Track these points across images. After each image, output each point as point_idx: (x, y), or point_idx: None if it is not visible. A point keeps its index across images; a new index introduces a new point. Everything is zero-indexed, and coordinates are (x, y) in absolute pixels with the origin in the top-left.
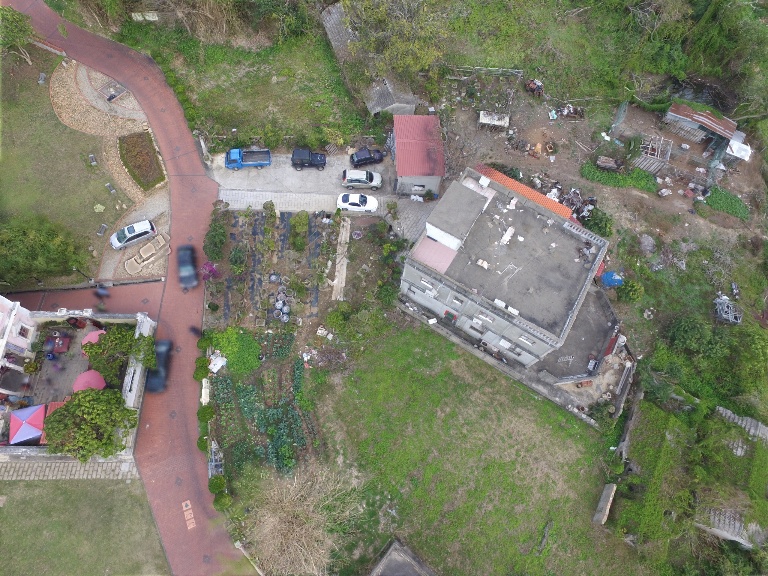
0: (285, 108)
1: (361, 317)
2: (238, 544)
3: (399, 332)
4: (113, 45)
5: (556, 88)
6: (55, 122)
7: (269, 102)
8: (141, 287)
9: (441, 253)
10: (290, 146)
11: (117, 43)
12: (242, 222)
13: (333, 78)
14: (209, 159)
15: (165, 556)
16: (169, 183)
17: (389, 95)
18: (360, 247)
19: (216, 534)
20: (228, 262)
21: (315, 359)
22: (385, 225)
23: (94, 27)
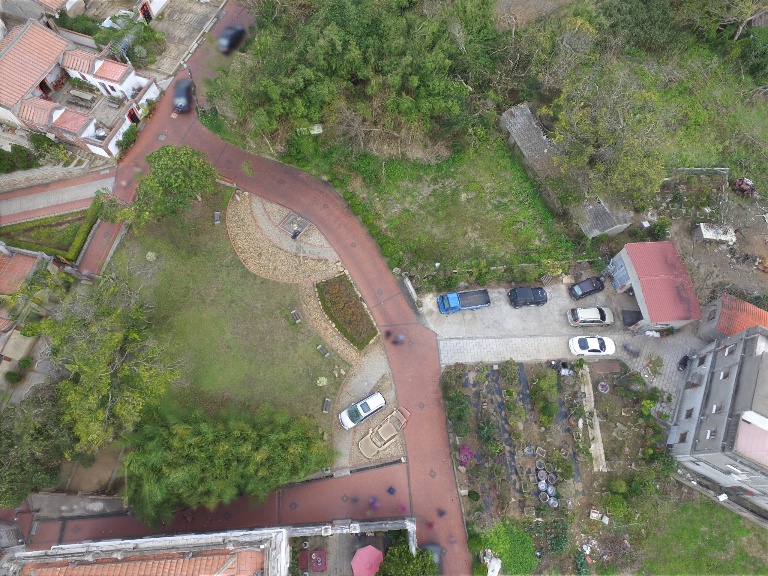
0: (485, 232)
1: (663, 511)
2: None
3: (679, 508)
4: (282, 168)
5: (763, 184)
6: (242, 271)
7: (467, 226)
8: (382, 472)
9: (760, 439)
10: (501, 279)
11: (285, 165)
12: (473, 380)
13: (529, 192)
14: (422, 305)
15: None
16: (381, 336)
17: (607, 215)
18: (607, 401)
19: None
20: (471, 433)
21: (597, 551)
22: (642, 379)
23: (258, 148)
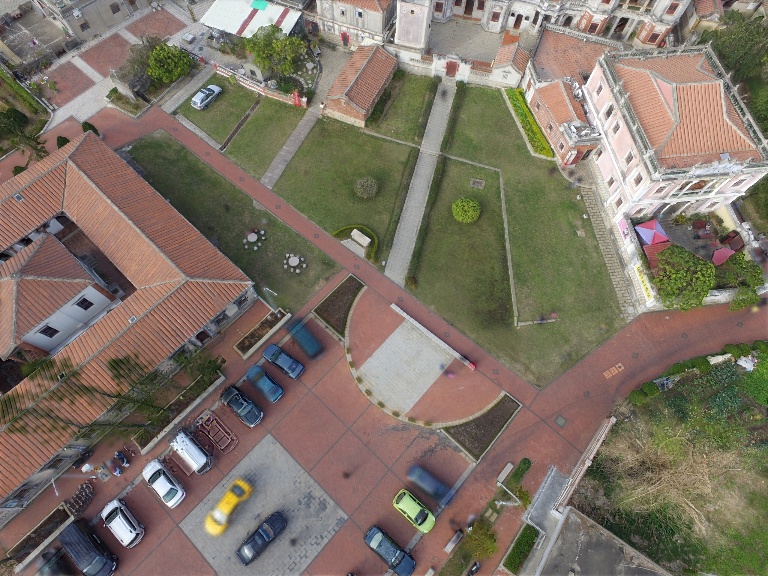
0: None
1: None
2: (614, 420)
3: None
4: None
5: None
6: None
7: None
8: None
9: None
10: None
11: None
12: None
13: None
14: None
15: (579, 360)
16: None
17: None
18: None
19: (607, 398)
20: None
21: None
22: None
23: None
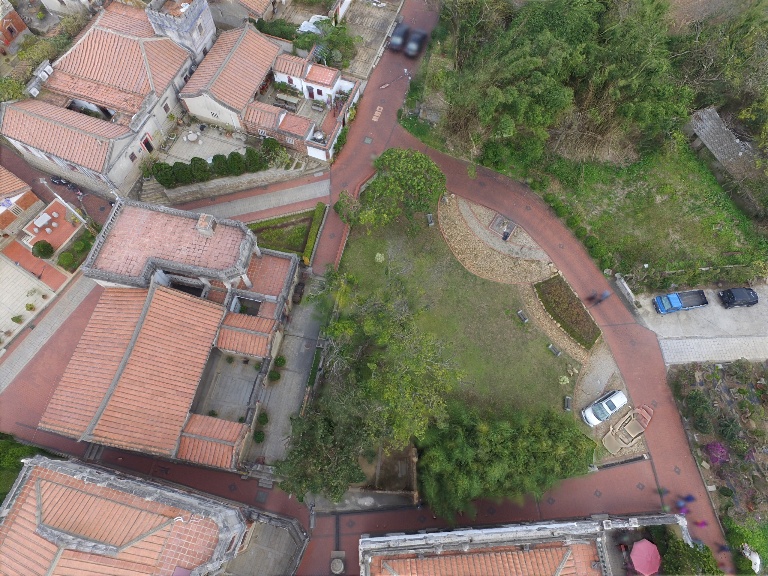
0: (686, 234)
1: None
2: None
3: None
4: (480, 170)
5: None
6: (462, 271)
7: (667, 228)
8: (628, 469)
9: None
10: (708, 280)
11: (483, 167)
12: (699, 378)
13: (723, 194)
14: None
15: None
16: (604, 336)
17: None
18: None
19: None
20: None
21: None
22: None
23: (456, 151)
